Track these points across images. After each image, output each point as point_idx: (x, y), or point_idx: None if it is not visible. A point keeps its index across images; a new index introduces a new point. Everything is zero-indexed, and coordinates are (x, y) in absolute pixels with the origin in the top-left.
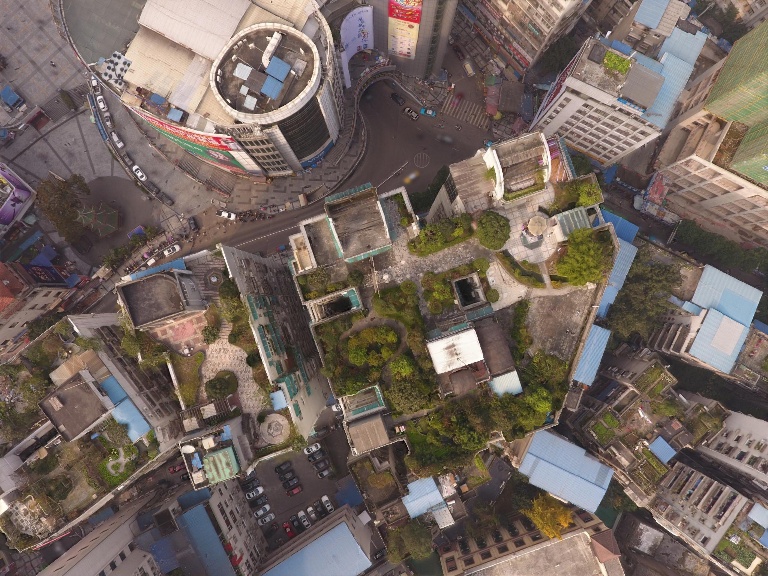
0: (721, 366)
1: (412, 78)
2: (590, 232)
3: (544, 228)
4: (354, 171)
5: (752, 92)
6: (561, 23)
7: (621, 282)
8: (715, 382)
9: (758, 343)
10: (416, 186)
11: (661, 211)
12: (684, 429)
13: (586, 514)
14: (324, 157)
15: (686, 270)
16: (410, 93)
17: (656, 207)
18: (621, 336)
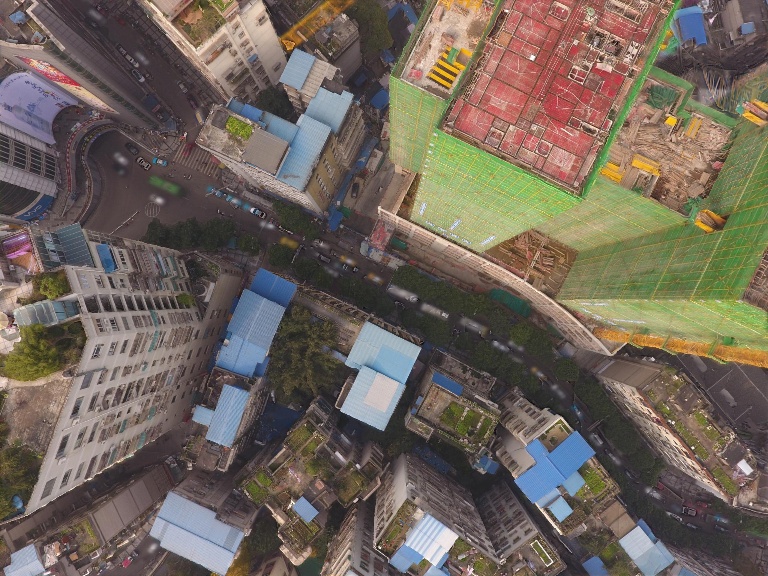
0: (375, 423)
1: (140, 129)
2: (37, 328)
3: (5, 322)
4: (85, 222)
5: (401, 150)
6: (231, 81)
7: (268, 342)
8: (413, 432)
9: (436, 396)
10: None
11: (386, 257)
12: (327, 489)
13: (270, 568)
14: (51, 209)
15: (353, 326)
16: (139, 143)
17: (381, 253)
18: (304, 390)
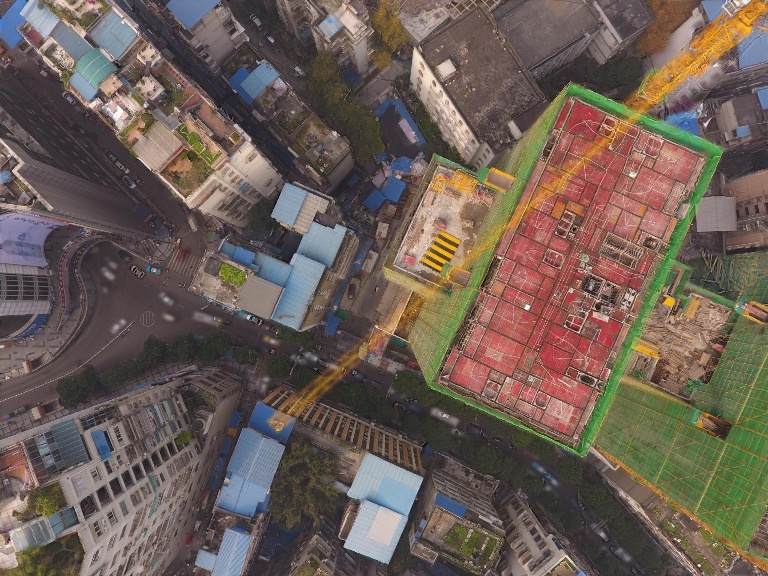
0: (379, 557)
1: (133, 238)
2: (34, 553)
3: (2, 543)
4: (80, 333)
5: None
6: (223, 209)
7: (269, 481)
8: None
9: (439, 518)
10: (143, 345)
11: (385, 361)
12: None
13: None
14: (45, 323)
15: (354, 454)
16: (132, 253)
17: (379, 358)
18: (306, 514)
